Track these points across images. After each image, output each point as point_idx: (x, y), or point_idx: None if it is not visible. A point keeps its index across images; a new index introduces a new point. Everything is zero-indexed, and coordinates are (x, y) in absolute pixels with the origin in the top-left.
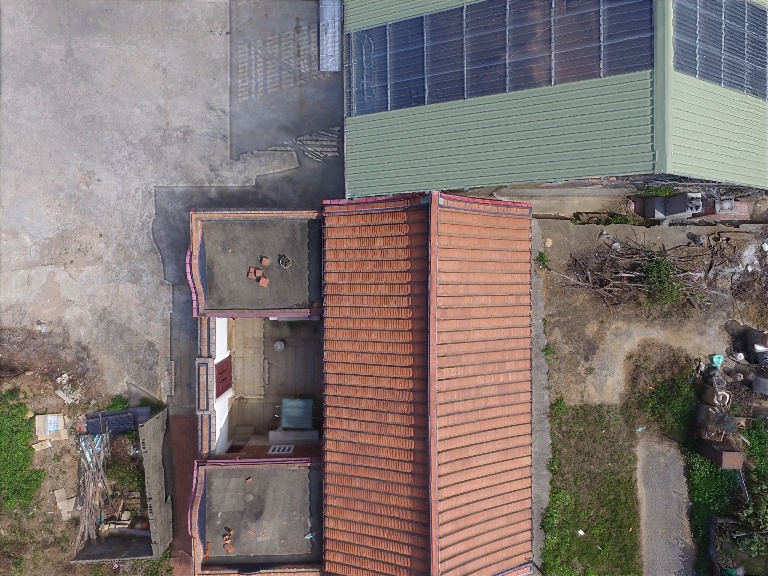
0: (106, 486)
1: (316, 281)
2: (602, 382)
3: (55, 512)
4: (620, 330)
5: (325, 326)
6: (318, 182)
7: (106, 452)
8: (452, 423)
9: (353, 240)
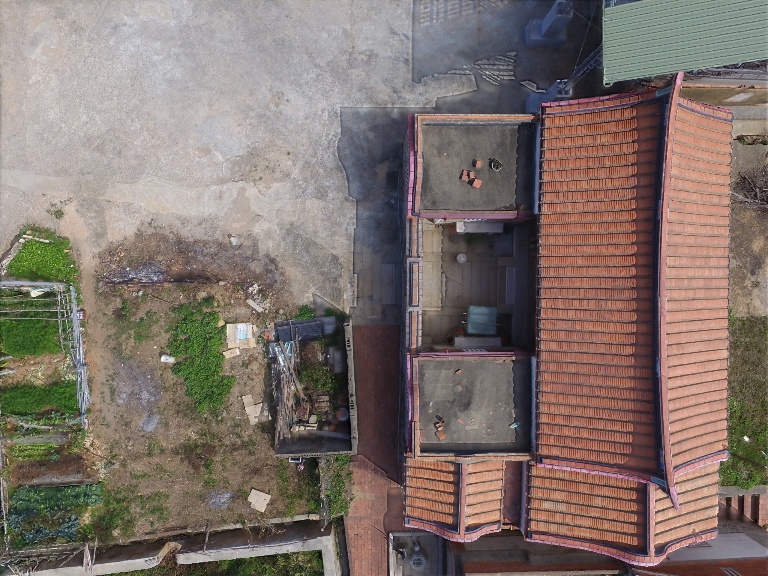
0: (298, 389)
1: (523, 184)
2: (767, 295)
3: (242, 417)
4: None
5: (540, 223)
6: (495, 104)
7: (296, 358)
8: (670, 309)
9: (574, 138)
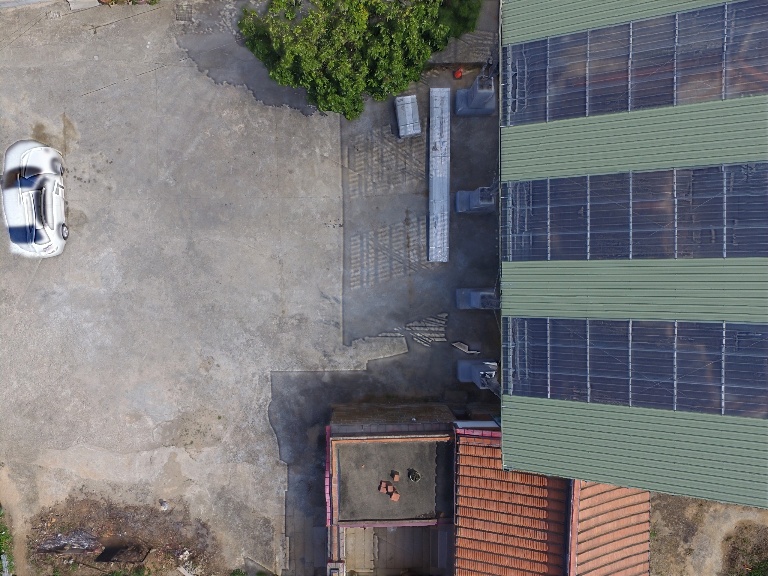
0: None
1: (443, 493)
2: (701, 562)
3: None
4: (718, 512)
5: (457, 545)
6: (426, 366)
7: None
8: None
9: (488, 471)
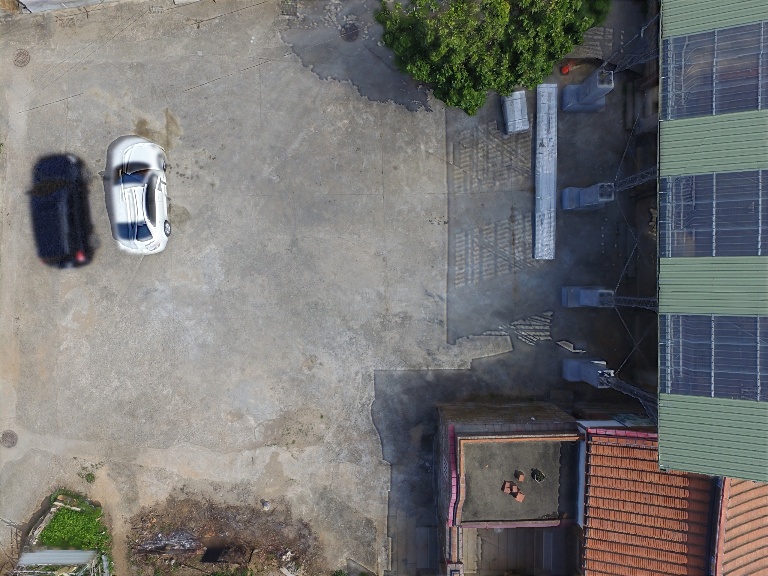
0: None
1: (566, 493)
2: None
3: None
4: None
5: (586, 546)
6: (531, 365)
7: None
8: None
9: (622, 471)
